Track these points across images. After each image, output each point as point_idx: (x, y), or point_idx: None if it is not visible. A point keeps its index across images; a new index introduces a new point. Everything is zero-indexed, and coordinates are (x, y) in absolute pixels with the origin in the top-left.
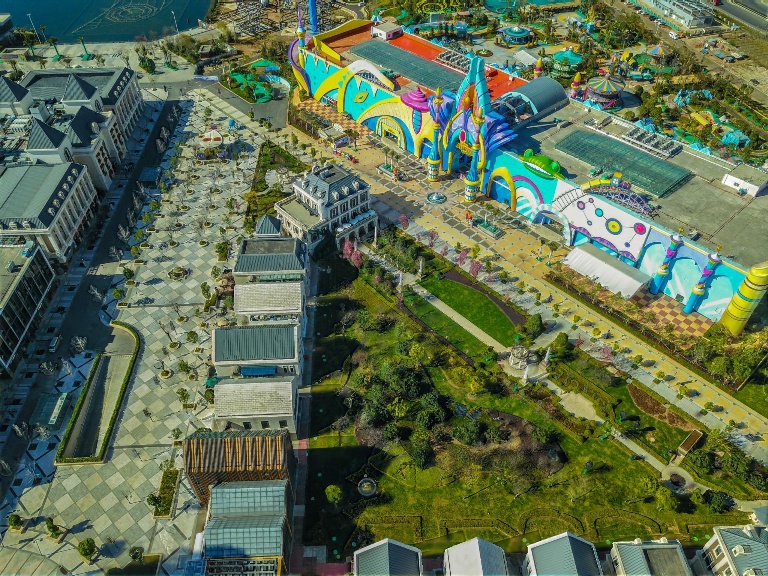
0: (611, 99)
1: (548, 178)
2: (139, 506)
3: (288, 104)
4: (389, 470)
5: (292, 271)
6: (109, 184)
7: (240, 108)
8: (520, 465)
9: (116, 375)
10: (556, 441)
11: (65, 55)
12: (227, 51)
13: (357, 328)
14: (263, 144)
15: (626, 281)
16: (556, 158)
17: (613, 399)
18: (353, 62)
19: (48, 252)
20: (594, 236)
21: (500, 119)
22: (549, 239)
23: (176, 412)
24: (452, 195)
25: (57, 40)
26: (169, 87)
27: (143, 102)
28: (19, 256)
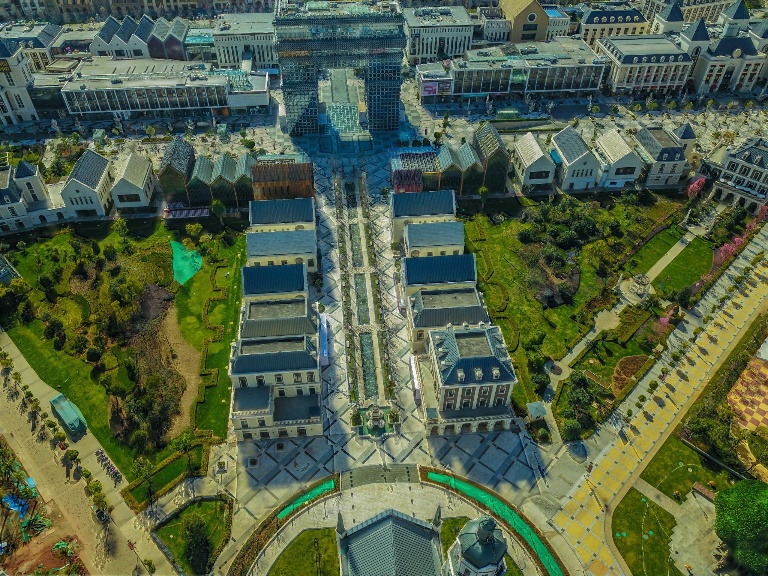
0: None
1: None
2: None
3: None
4: (512, 225)
5: (651, 157)
6: None
7: None
8: (537, 282)
9: None
10: (565, 302)
11: None
12: None
13: None
14: None
15: None
16: None
17: None
18: None
19: (613, 80)
20: None
21: None
22: None
23: None
24: None
25: None
26: None
27: None
28: None
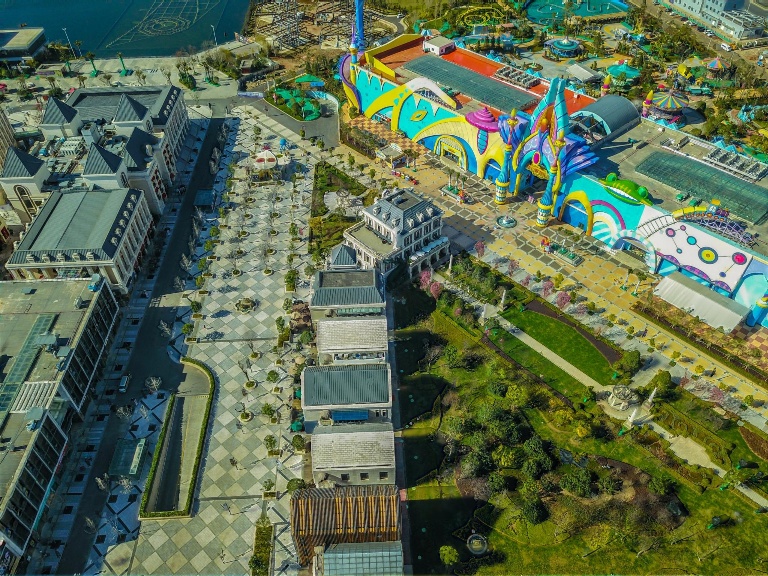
0: (675, 115)
1: (634, 204)
2: (234, 566)
3: (338, 122)
4: (498, 525)
5: (372, 305)
6: (162, 208)
7: (289, 126)
8: (638, 519)
9: (192, 417)
10: (673, 491)
11: (102, 71)
12: (268, 66)
13: (442, 365)
14: (317, 164)
15: (725, 314)
16: (638, 182)
17: (727, 444)
18: (412, 80)
19: (110, 283)
20: (683, 264)
21: (581, 142)
22: (631, 266)
23: (261, 459)
24: (522, 219)
25: (94, 56)
26: (213, 104)
27: (188, 120)
28: (85, 290)
